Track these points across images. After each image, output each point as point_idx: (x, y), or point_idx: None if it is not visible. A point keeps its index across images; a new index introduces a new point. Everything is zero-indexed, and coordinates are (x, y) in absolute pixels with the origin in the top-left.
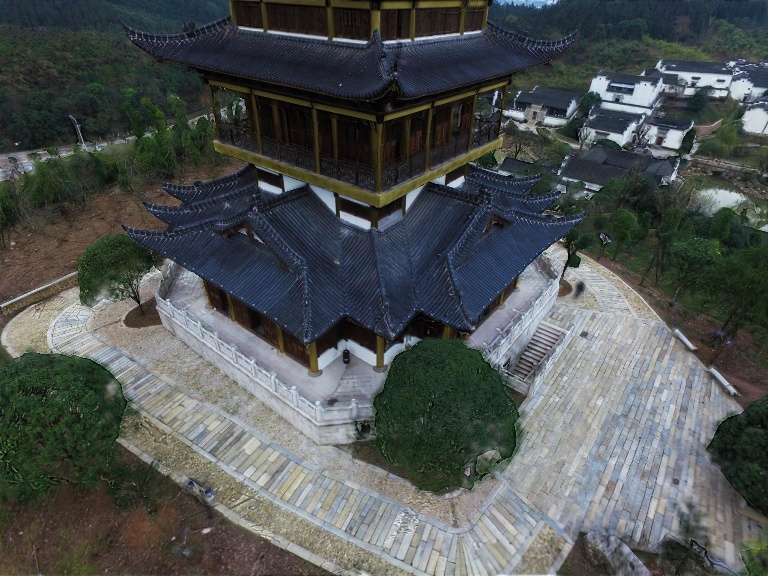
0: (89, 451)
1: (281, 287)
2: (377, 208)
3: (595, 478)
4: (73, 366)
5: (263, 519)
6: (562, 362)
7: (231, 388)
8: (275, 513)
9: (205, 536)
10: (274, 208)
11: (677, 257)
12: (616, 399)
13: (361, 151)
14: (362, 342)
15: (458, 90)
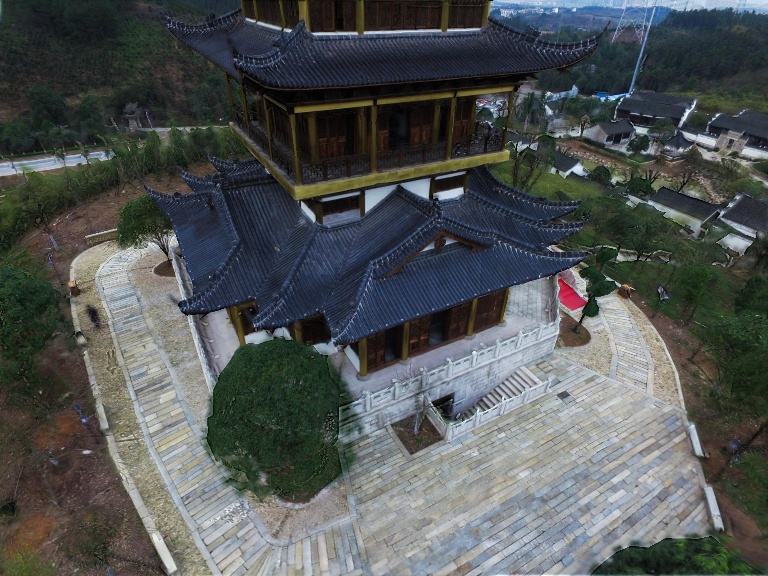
0: (5, 353)
1: (217, 260)
2: (320, 202)
3: (453, 552)
4: (20, 284)
5: (131, 460)
6: (512, 417)
7: (188, 344)
8: (143, 459)
9: (82, 456)
10: (242, 188)
11: (717, 333)
12: (547, 478)
13: (307, 143)
14: (291, 332)
15: (418, 90)
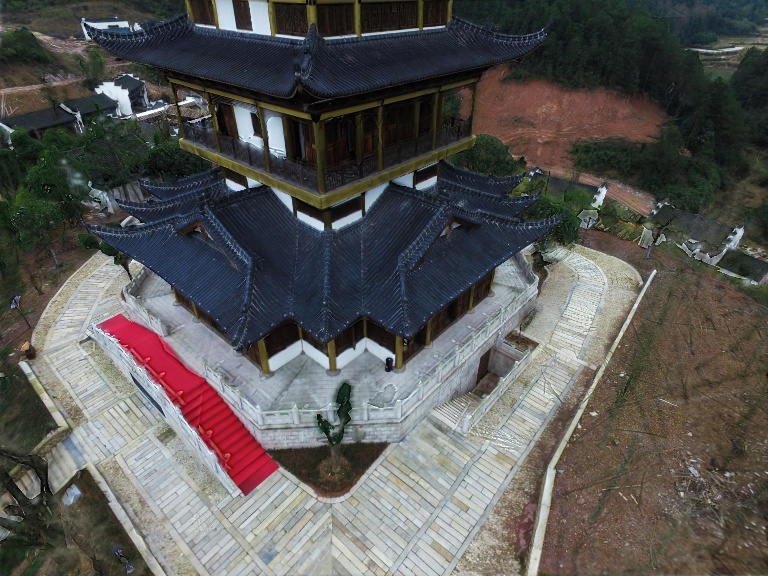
0: None
1: None
2: None
3: None
4: None
5: None
6: None
7: None
8: None
9: None
10: None
11: None
12: None
13: None
14: None
15: None
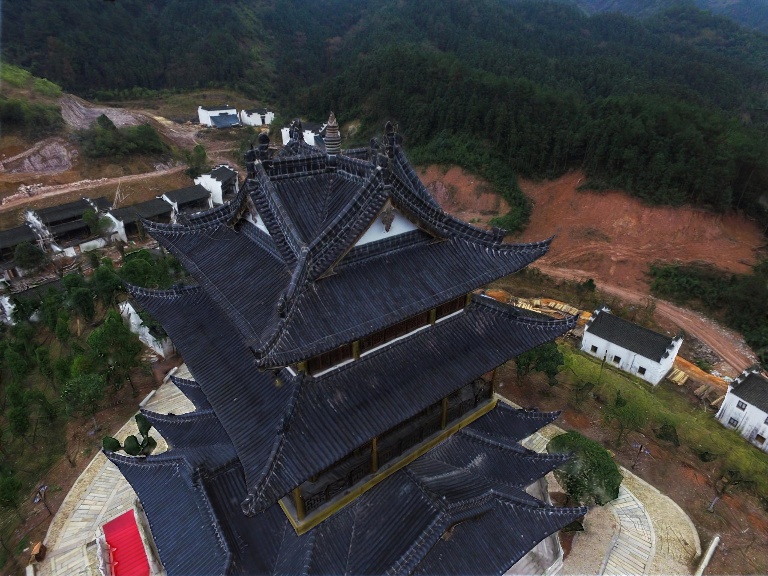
0: None
1: None
2: None
3: None
4: None
5: None
6: None
7: None
8: None
9: None
10: None
11: None
12: None
13: None
14: None
15: None
